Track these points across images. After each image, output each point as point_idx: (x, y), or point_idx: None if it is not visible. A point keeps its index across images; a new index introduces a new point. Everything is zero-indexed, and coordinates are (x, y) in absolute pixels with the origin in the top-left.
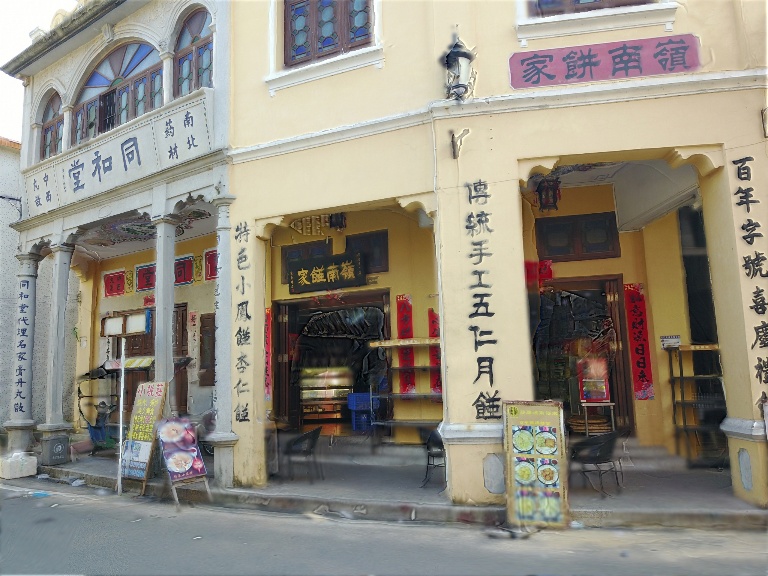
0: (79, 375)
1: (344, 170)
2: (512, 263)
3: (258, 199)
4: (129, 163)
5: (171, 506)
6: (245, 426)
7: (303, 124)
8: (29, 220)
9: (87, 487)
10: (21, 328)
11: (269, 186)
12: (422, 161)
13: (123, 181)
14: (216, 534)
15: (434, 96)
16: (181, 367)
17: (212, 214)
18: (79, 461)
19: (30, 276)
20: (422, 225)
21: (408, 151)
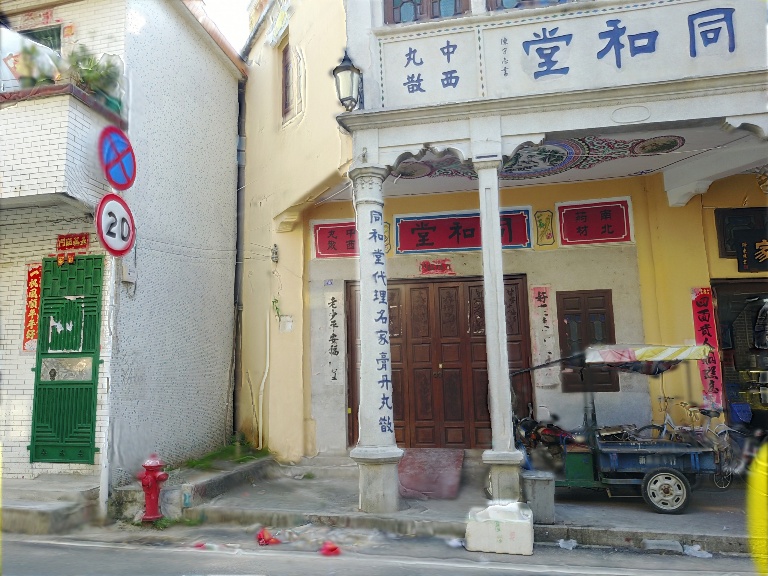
0: (280, 374)
1: None
2: None
3: None
4: (705, 46)
5: None
6: None
7: None
8: (400, 112)
9: (743, 558)
10: (380, 289)
11: None
12: None
13: (680, 72)
14: None
15: None
16: (672, 363)
17: (675, 150)
18: (557, 512)
19: (380, 205)
20: None
21: None
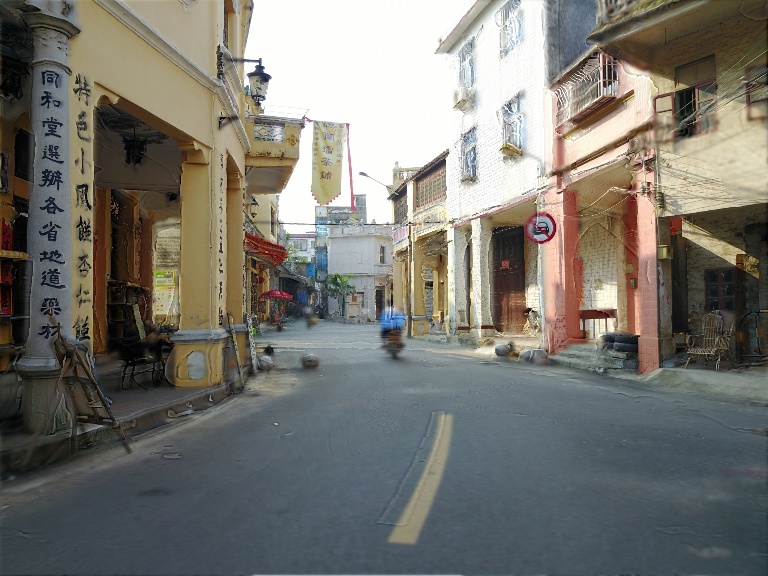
0: None
1: (166, 87)
2: (225, 219)
3: (98, 57)
4: None
5: (127, 446)
6: (86, 345)
7: (136, 5)
8: None
9: None
10: None
11: (106, 49)
12: (206, 119)
13: None
14: (260, 423)
15: (211, 71)
16: None
17: None
18: None
19: None
20: (5, 117)
21: (199, 104)
